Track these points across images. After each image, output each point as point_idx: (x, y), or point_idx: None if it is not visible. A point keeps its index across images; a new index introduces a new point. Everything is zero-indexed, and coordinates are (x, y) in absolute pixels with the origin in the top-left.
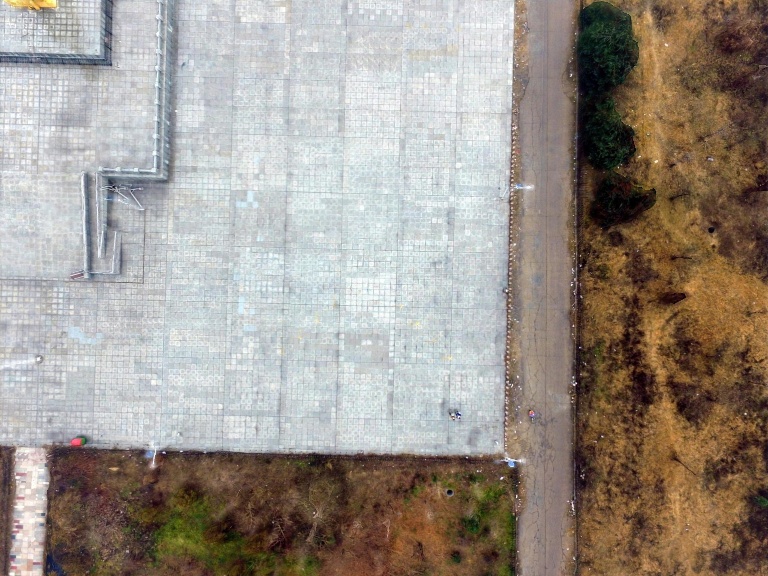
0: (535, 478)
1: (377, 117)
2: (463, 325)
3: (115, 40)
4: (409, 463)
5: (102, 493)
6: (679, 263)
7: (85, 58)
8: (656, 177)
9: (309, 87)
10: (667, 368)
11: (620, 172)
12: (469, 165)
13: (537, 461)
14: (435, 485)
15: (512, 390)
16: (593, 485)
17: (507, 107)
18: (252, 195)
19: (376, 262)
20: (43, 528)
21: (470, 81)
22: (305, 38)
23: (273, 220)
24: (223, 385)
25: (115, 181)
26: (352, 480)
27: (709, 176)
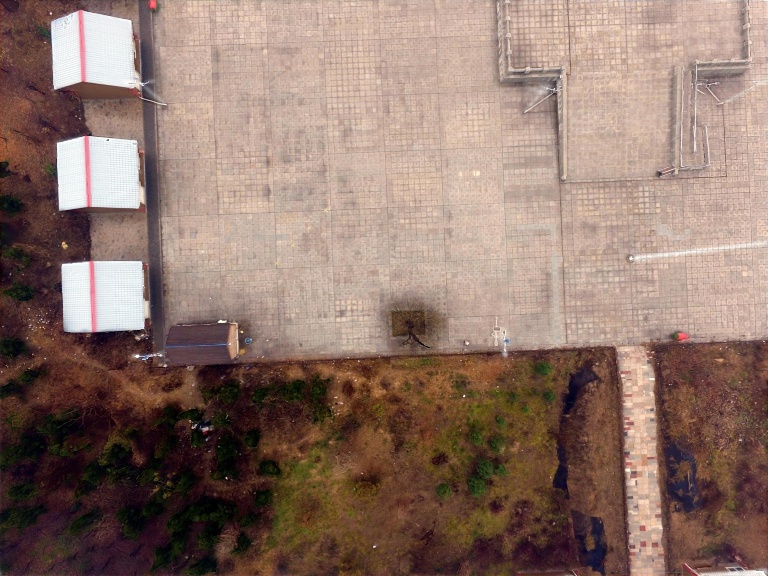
0: None
1: None
2: None
3: None
4: None
5: (710, 384)
6: None
7: None
8: None
9: None
10: None
11: None
12: None
13: None
14: None
15: None
16: None
17: None
18: None
19: None
20: (654, 423)
21: None
22: None
23: None
24: None
25: None
26: None
27: None
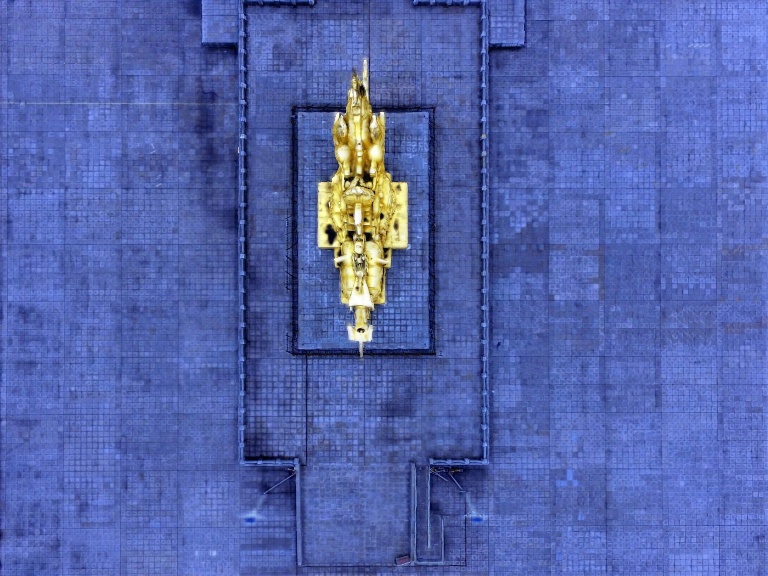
0: None
1: (694, 391)
2: None
3: (438, 329)
4: None
5: None
6: None
7: (410, 349)
8: None
9: (625, 363)
10: None
11: None
12: None
13: None
14: None
15: None
16: None
17: None
18: (572, 473)
19: (698, 538)
20: None
21: None
22: (619, 314)
23: (593, 498)
24: None
25: None
26: None
27: None
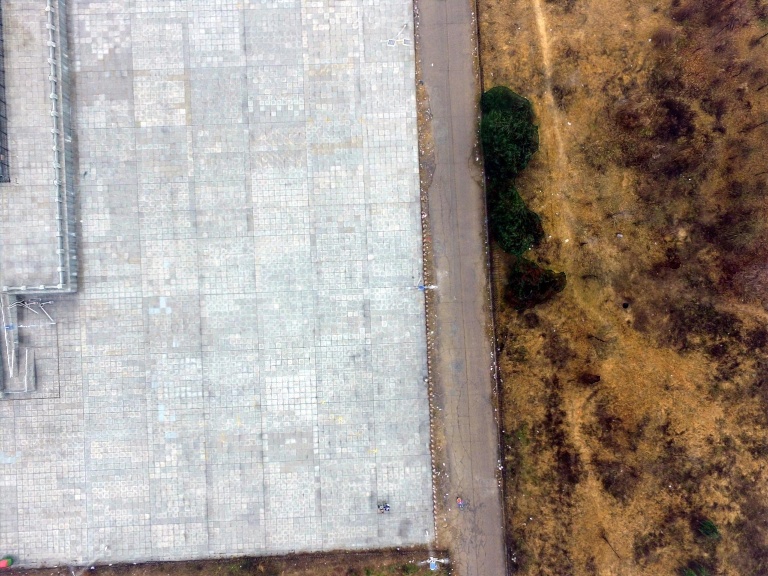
0: (467, 564)
1: (286, 214)
2: (386, 417)
3: (12, 156)
4: (341, 559)
5: None
6: (595, 341)
7: None
8: (568, 256)
9: (215, 188)
10: (590, 446)
11: (532, 253)
12: (381, 256)
13: (468, 547)
14: None
15: (439, 478)
16: (525, 567)
17: (415, 195)
18: (165, 301)
19: (294, 360)
20: None
21: (376, 172)
22: (207, 139)
23: (188, 325)
24: (148, 495)
25: (24, 296)
26: None
27: (620, 252)
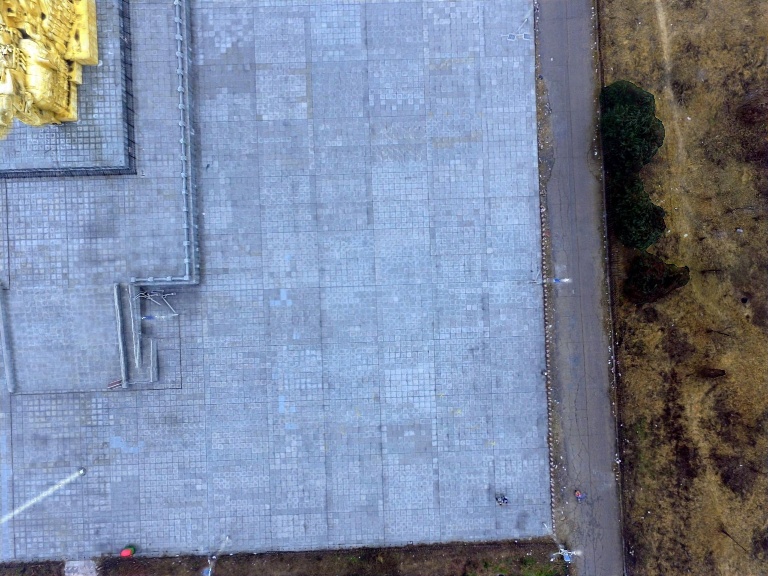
0: (585, 557)
1: (405, 207)
2: (504, 410)
3: (138, 148)
4: (459, 551)
5: None
6: (715, 335)
7: (109, 169)
8: (686, 251)
9: (335, 181)
10: (709, 440)
11: (651, 248)
12: (500, 250)
13: (586, 540)
14: (486, 571)
15: (556, 471)
16: (643, 561)
17: (534, 189)
18: (285, 293)
19: (413, 352)
20: None
21: (496, 166)
22: (328, 132)
23: (308, 317)
24: (268, 485)
25: (147, 288)
26: (403, 572)
27: (739, 247)
